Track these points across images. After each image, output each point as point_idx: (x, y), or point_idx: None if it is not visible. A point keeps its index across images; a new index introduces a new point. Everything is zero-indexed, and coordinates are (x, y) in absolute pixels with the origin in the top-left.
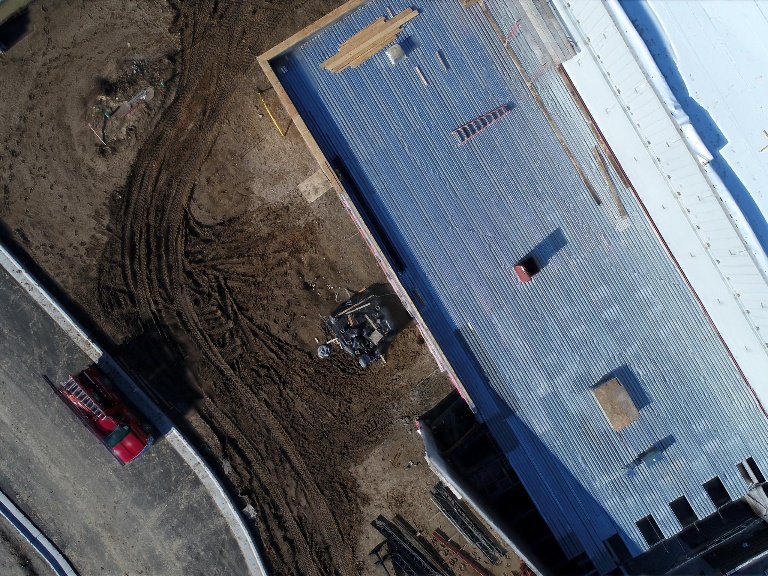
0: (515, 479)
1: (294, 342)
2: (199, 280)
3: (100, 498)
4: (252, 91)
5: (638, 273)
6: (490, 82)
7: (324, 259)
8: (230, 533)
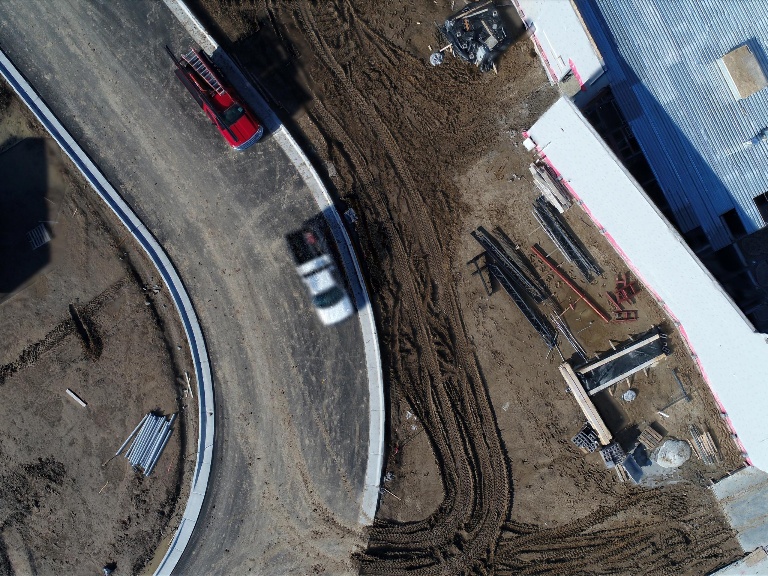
0: (636, 148)
1: (408, 48)
2: None
3: (203, 193)
4: None
5: None
6: None
7: None
8: (330, 236)
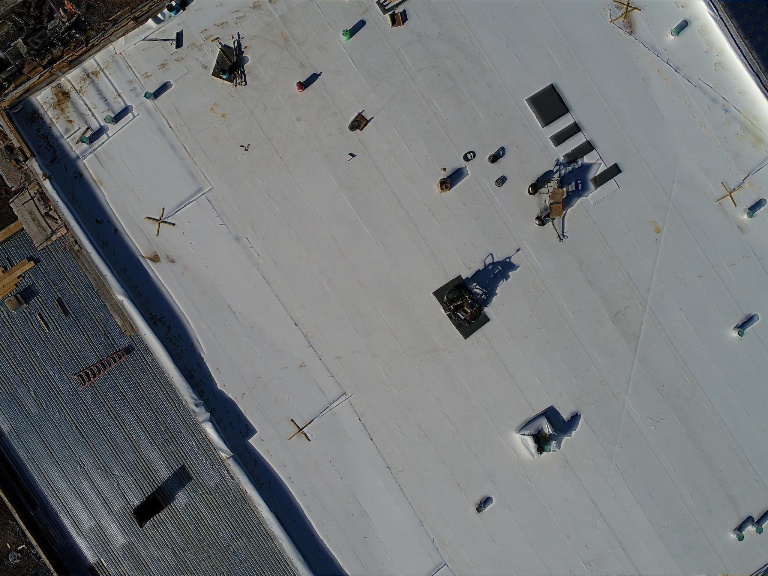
0: None
1: None
2: None
3: None
4: None
5: None
6: (109, 326)
7: None
8: None
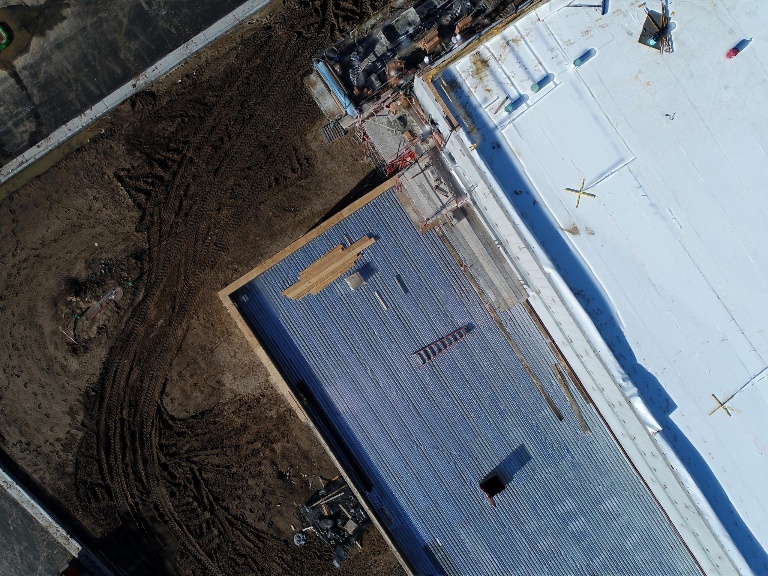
0: None
1: (270, 530)
2: (174, 472)
3: None
4: (219, 287)
5: (602, 486)
6: (449, 304)
7: (297, 448)
8: None
